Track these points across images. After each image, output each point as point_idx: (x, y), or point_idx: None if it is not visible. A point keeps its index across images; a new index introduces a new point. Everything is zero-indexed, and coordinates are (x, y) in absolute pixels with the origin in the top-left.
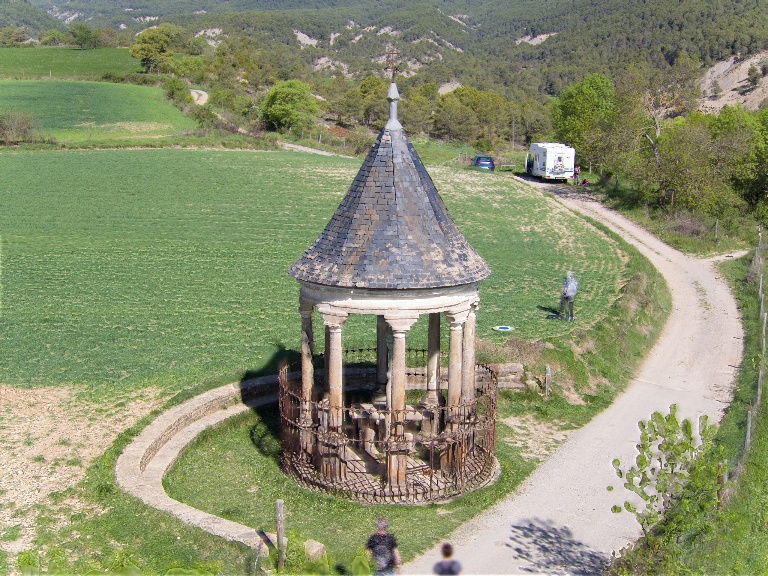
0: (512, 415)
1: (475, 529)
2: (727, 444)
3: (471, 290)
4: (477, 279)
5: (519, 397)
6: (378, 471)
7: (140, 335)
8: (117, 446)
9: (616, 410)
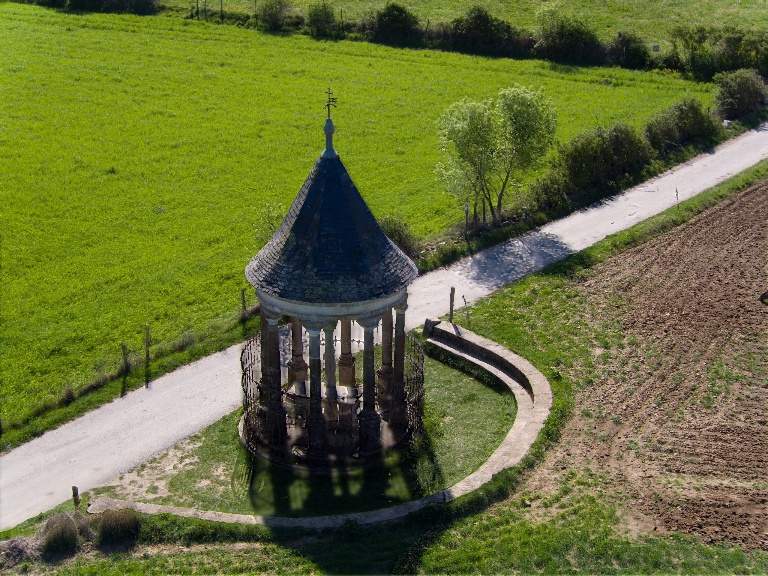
0: (148, 500)
1: None
2: (2, 440)
3: None
4: None
5: None
6: None
7: None
8: (556, 415)
9: (1, 526)
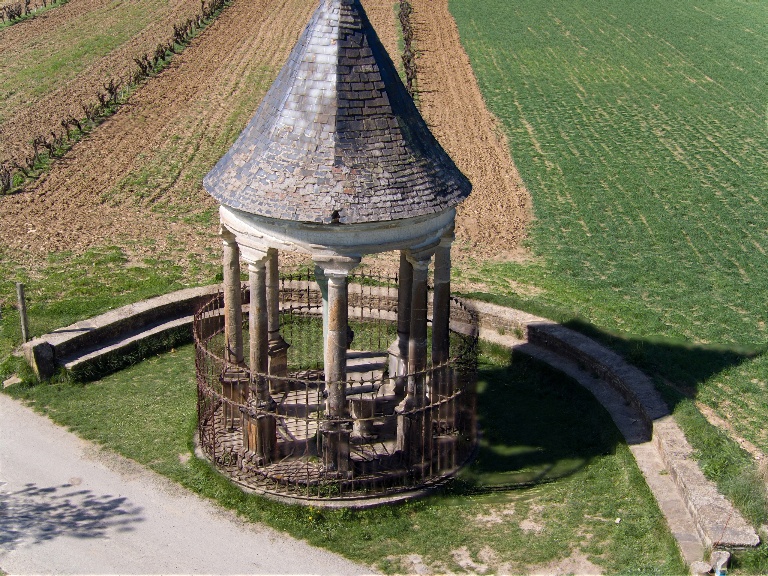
0: (607, 568)
1: (124, 470)
2: None
3: (275, 229)
4: (245, 208)
5: (669, 569)
6: (283, 410)
7: (762, 278)
8: None
9: None
